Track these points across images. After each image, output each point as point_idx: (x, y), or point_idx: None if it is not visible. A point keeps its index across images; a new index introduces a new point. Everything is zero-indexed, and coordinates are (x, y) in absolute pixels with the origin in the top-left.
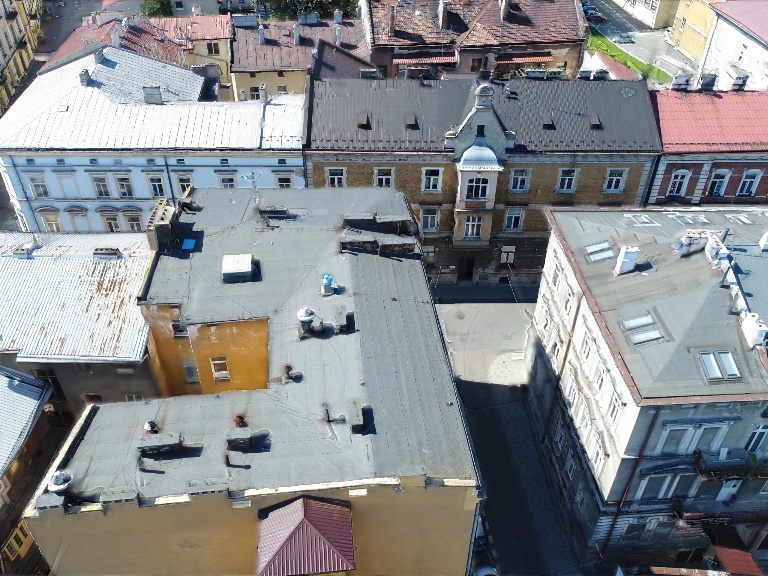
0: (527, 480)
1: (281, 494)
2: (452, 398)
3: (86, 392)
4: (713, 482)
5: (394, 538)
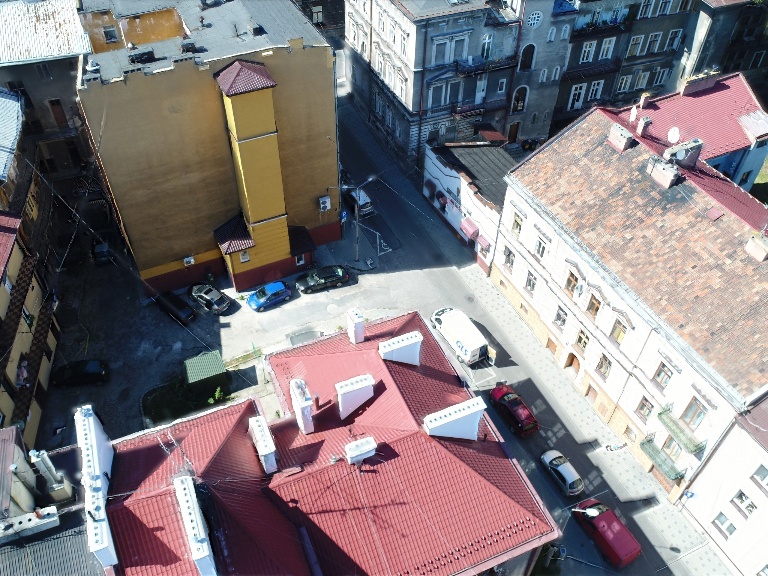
0: (364, 143)
1: (225, 59)
2: (306, 21)
3: (49, 98)
4: (470, 87)
5: (292, 96)
